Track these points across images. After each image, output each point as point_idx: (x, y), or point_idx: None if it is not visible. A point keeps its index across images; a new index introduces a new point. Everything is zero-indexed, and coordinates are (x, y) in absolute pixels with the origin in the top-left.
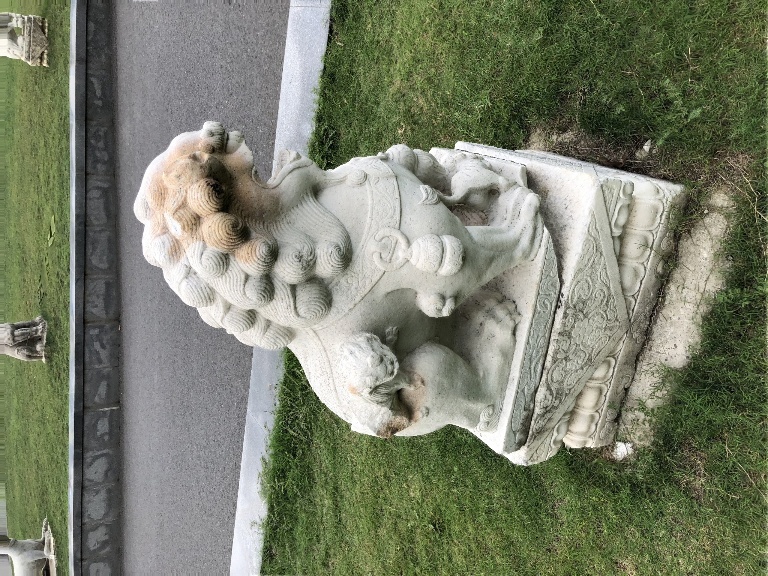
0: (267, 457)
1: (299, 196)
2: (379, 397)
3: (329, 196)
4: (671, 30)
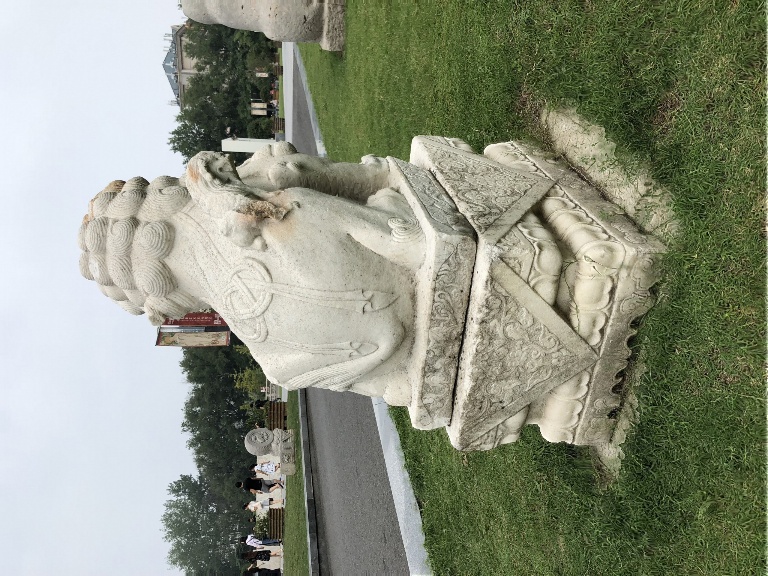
0: None
1: None
2: (229, 188)
3: None
4: None
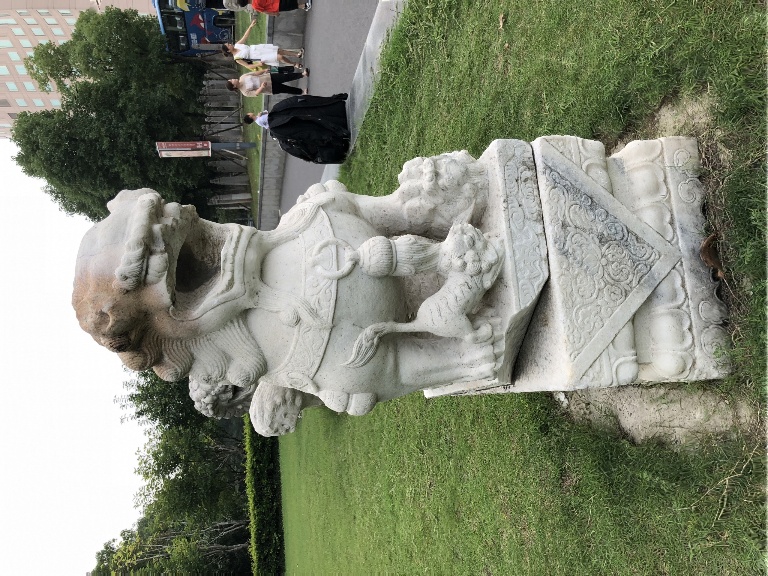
0: (390, 37)
1: (221, 325)
2: None
3: (259, 319)
4: None
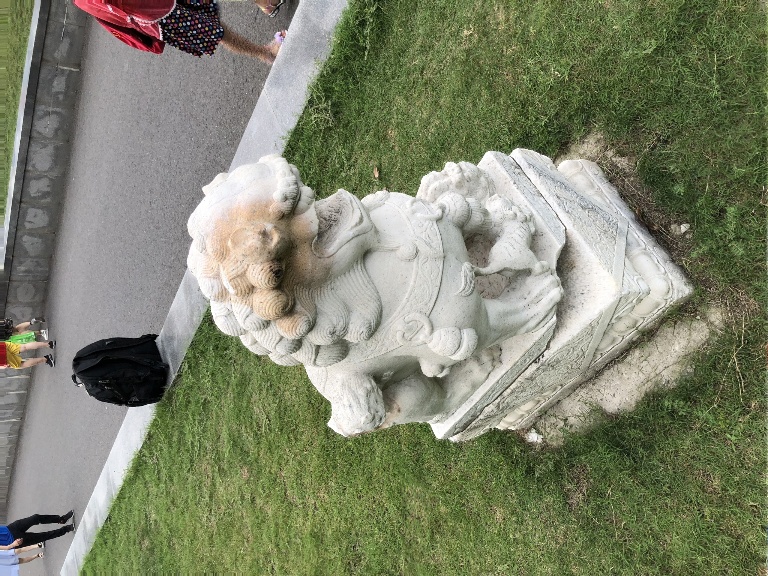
0: None
1: (349, 265)
2: None
3: (376, 262)
4: (767, 149)
